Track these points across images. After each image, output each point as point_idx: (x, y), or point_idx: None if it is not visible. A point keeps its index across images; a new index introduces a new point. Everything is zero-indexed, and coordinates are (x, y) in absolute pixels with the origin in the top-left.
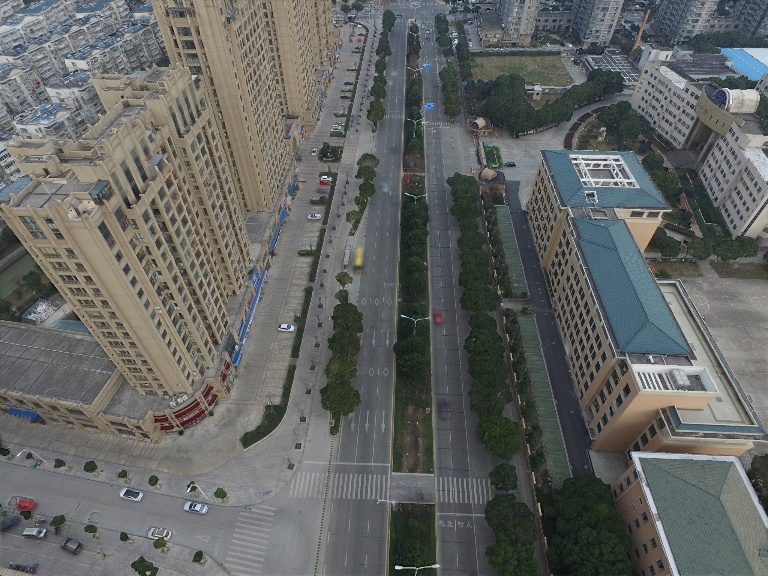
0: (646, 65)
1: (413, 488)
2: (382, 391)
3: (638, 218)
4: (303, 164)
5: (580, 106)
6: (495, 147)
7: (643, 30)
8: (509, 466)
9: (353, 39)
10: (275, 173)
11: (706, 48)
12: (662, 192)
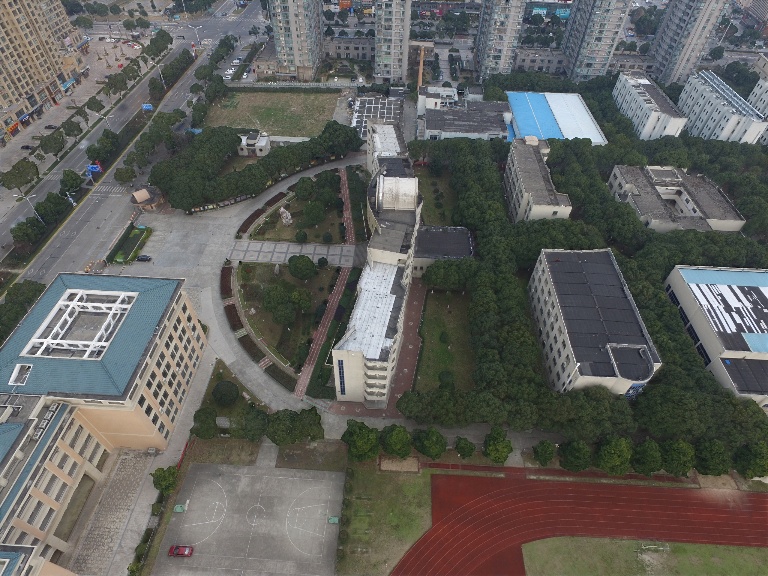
0: (367, 123)
1: None
2: None
3: (97, 405)
4: None
5: (307, 167)
6: (149, 229)
7: (459, 62)
8: None
9: (115, 64)
10: None
11: (491, 94)
12: (273, 320)
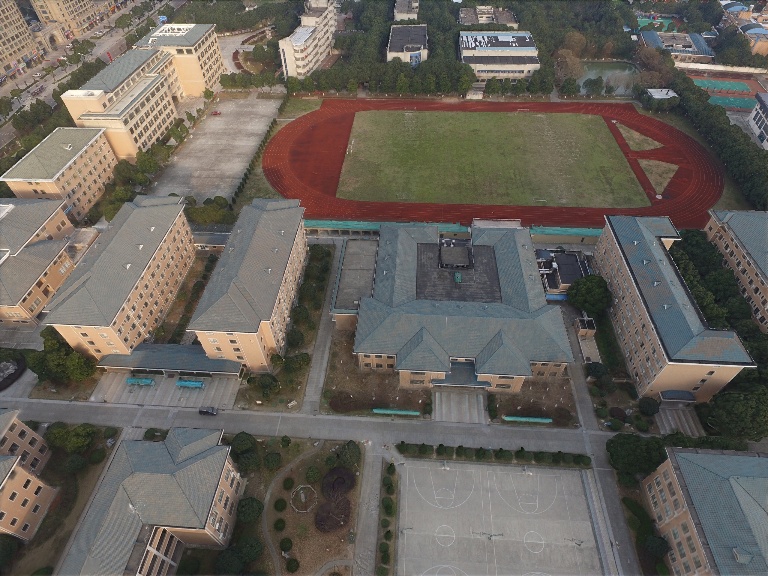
0: None
1: None
2: (5, 140)
3: (182, 54)
4: (56, 52)
5: None
6: None
7: None
8: None
9: None
10: (6, 44)
11: None
12: (257, 57)
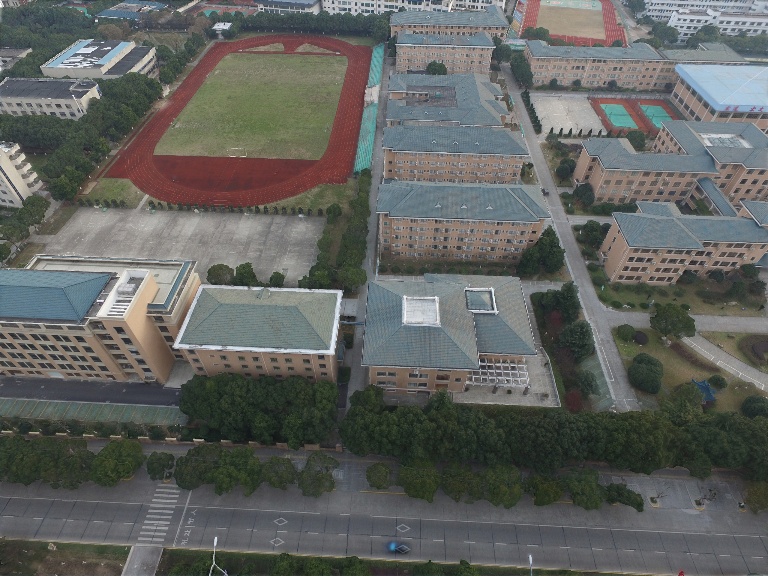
0: None
1: (139, 574)
2: None
3: None
4: None
5: None
6: None
7: None
8: (151, 457)
9: None
10: None
11: None
12: None
